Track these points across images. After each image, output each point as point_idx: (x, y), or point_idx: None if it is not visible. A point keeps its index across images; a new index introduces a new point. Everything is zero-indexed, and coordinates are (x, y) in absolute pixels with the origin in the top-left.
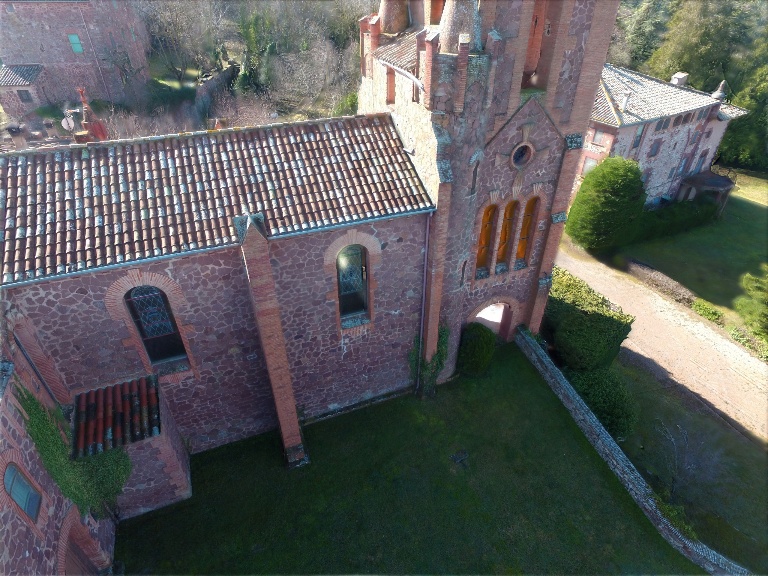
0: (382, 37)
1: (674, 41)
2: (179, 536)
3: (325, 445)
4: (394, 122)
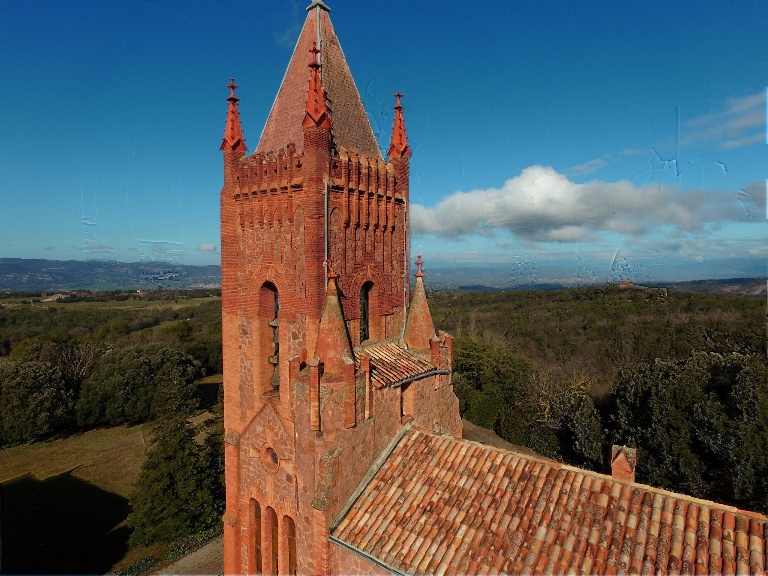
0: None
1: None
2: None
3: None
4: None
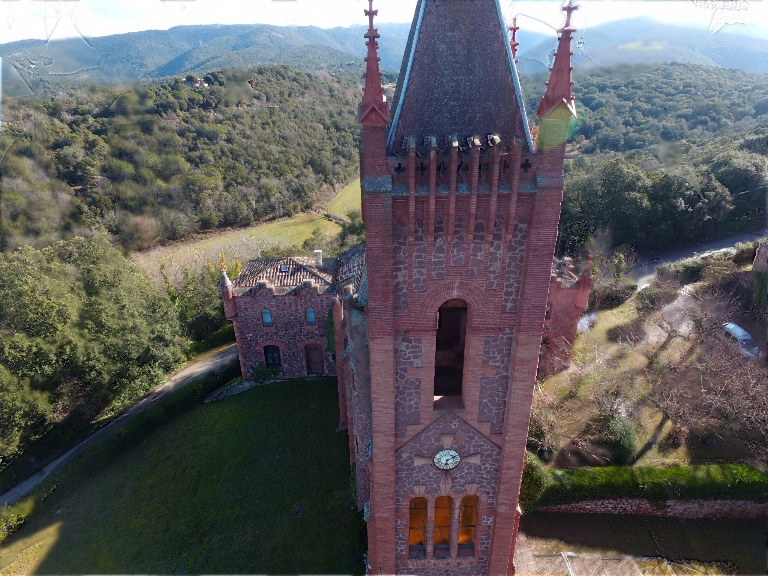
0: None
1: None
2: (327, 391)
3: (343, 441)
4: None
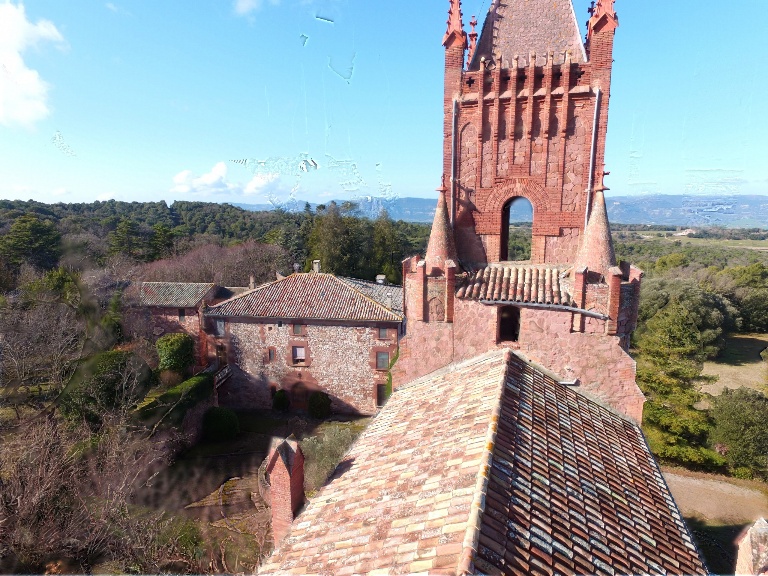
0: (457, 278)
1: (323, 255)
2: None
3: None
4: (523, 359)
